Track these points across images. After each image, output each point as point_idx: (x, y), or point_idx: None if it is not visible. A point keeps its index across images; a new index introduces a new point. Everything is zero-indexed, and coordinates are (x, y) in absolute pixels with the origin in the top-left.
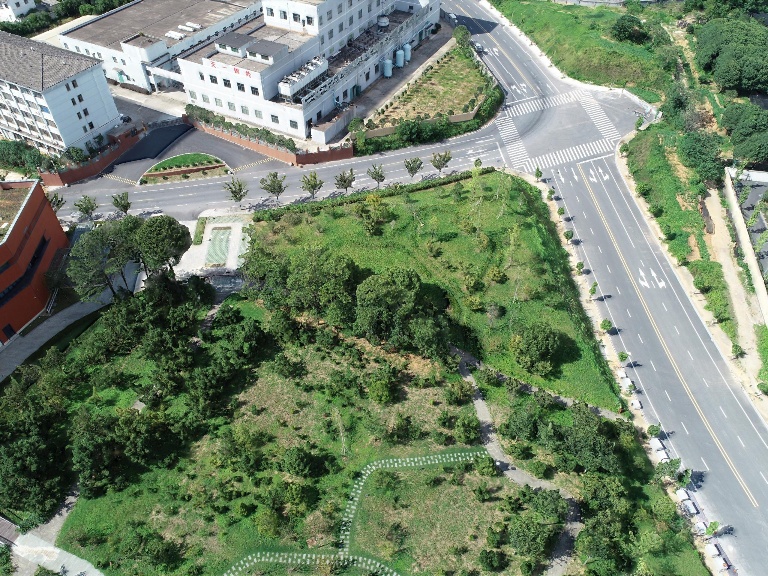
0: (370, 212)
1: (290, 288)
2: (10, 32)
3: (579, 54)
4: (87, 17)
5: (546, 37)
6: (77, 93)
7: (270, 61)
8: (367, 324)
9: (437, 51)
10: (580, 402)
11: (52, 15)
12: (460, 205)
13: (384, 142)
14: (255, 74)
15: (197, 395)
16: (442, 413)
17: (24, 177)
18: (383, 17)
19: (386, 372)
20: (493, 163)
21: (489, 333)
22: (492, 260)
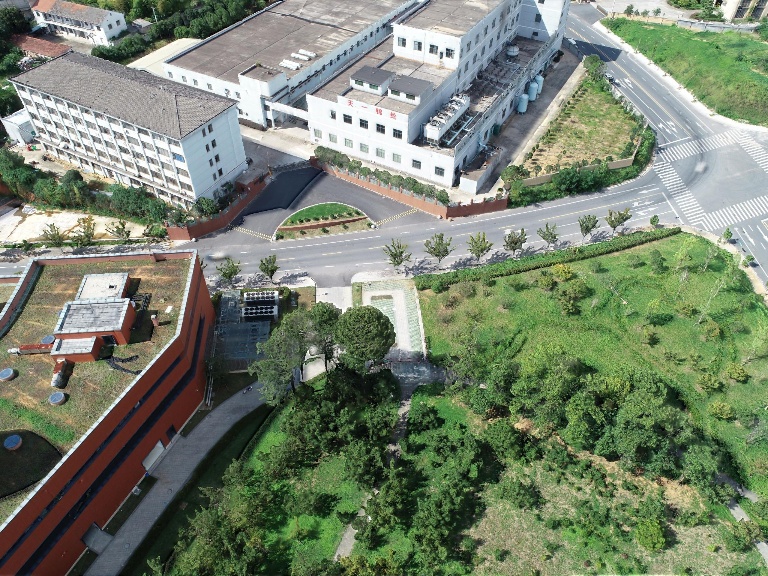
0: (559, 284)
1: (516, 394)
2: (106, 58)
3: (730, 89)
4: (184, 40)
5: (682, 67)
6: (211, 138)
7: (416, 101)
8: (633, 452)
9: (566, 82)
10: None
11: (145, 38)
12: (664, 278)
13: (539, 192)
14: (402, 116)
15: (432, 538)
16: (735, 568)
17: (145, 229)
18: (514, 46)
19: (656, 510)
20: (666, 219)
21: (745, 448)
22: (724, 352)
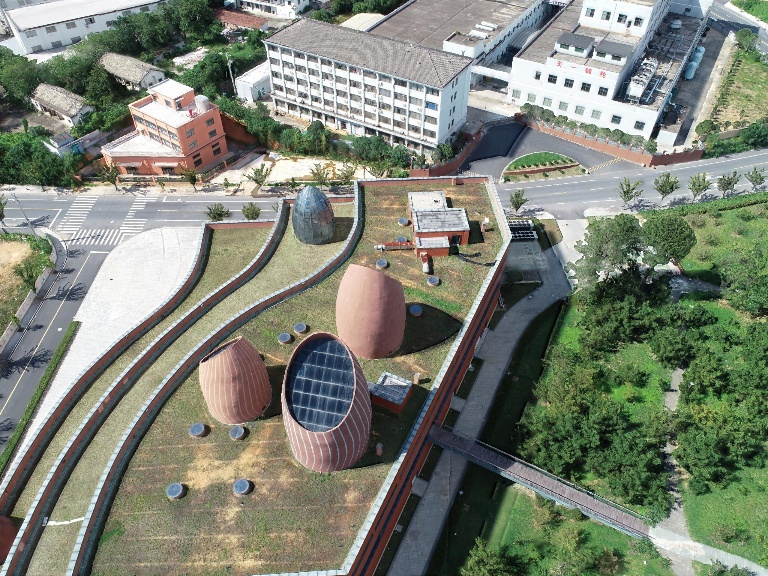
0: None
1: None
2: None
3: None
4: (364, 15)
5: None
6: (455, 90)
7: (622, 62)
8: None
9: (719, 54)
10: None
11: None
12: None
13: (729, 145)
14: (612, 74)
15: (757, 395)
16: None
17: None
18: (678, 19)
19: None
20: None
21: None
22: None
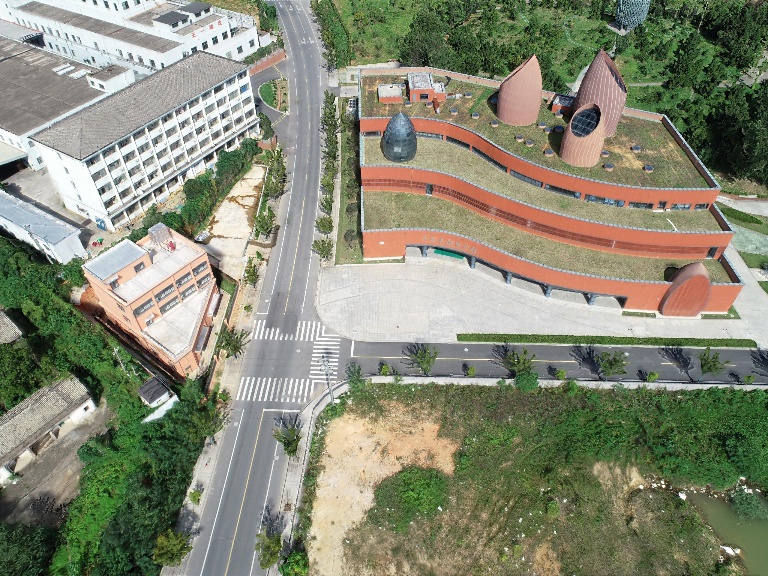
0: None
1: None
2: None
3: None
4: None
5: None
6: None
7: (211, 11)
8: None
9: None
10: None
11: None
12: None
13: None
14: (224, 19)
15: None
16: None
17: None
18: None
19: None
20: (306, 5)
21: None
22: None
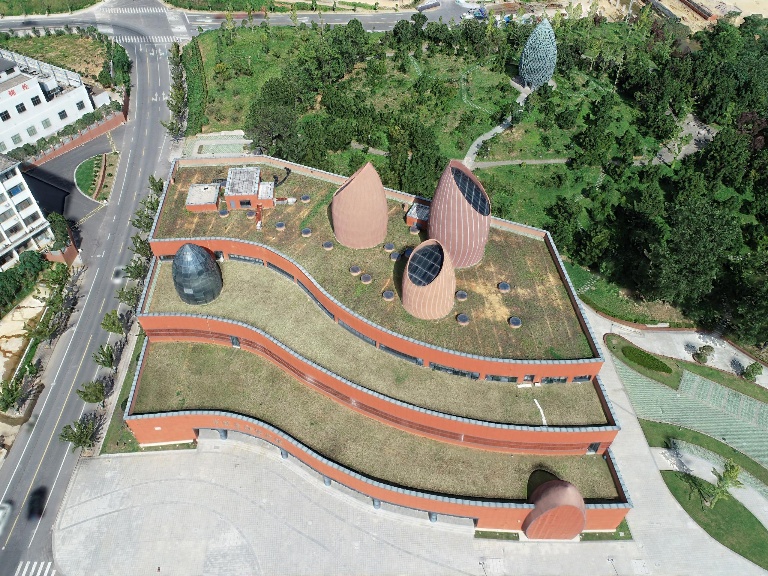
0: None
1: None
2: None
3: None
4: None
5: (3, 7)
6: None
7: (16, 71)
8: None
9: None
10: (386, 33)
11: None
12: None
13: None
14: (32, 81)
15: None
16: (394, 56)
17: None
18: None
19: None
20: None
21: None
22: None
